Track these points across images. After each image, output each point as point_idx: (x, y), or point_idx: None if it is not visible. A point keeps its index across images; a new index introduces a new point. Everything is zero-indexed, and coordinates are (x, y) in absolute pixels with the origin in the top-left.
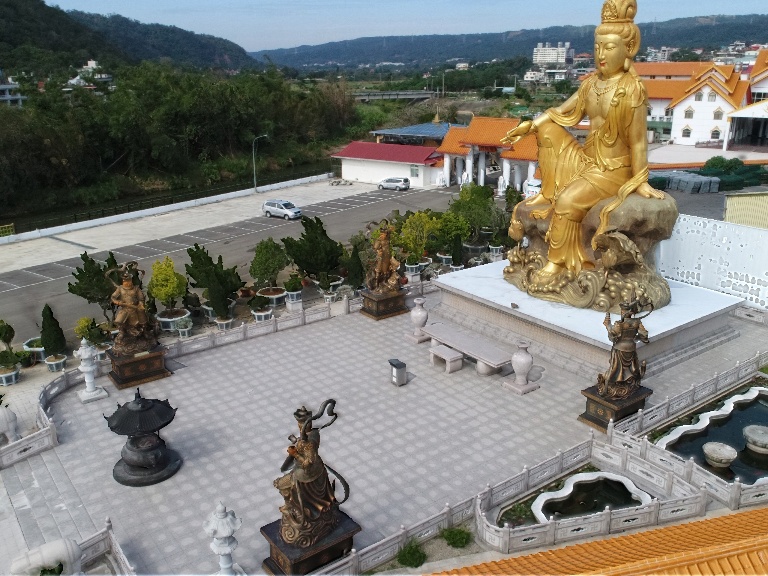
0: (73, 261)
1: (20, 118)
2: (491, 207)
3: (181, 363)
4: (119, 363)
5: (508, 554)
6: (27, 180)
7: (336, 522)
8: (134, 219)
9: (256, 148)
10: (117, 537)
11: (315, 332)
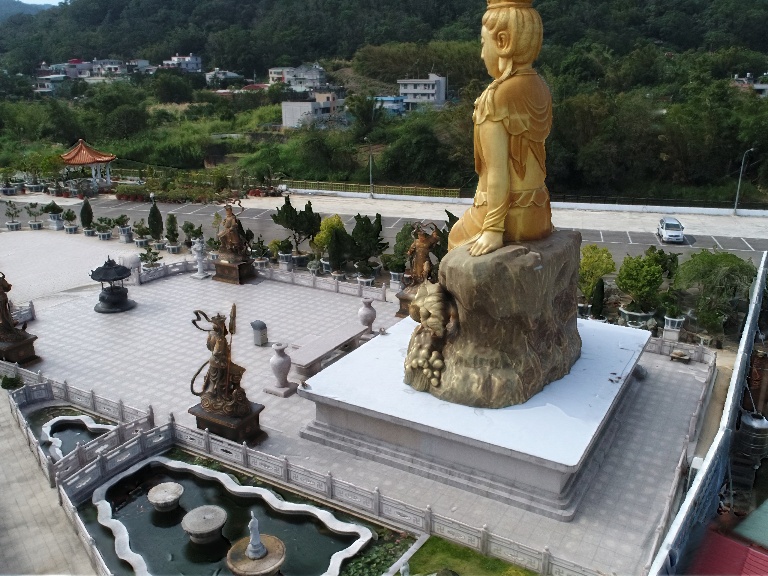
0: (436, 222)
1: (647, 113)
2: (718, 268)
3: (261, 282)
4: (213, 262)
5: (11, 412)
6: (634, 170)
7: (6, 339)
8: (563, 209)
9: (746, 163)
10: (46, 317)
11: (348, 303)
